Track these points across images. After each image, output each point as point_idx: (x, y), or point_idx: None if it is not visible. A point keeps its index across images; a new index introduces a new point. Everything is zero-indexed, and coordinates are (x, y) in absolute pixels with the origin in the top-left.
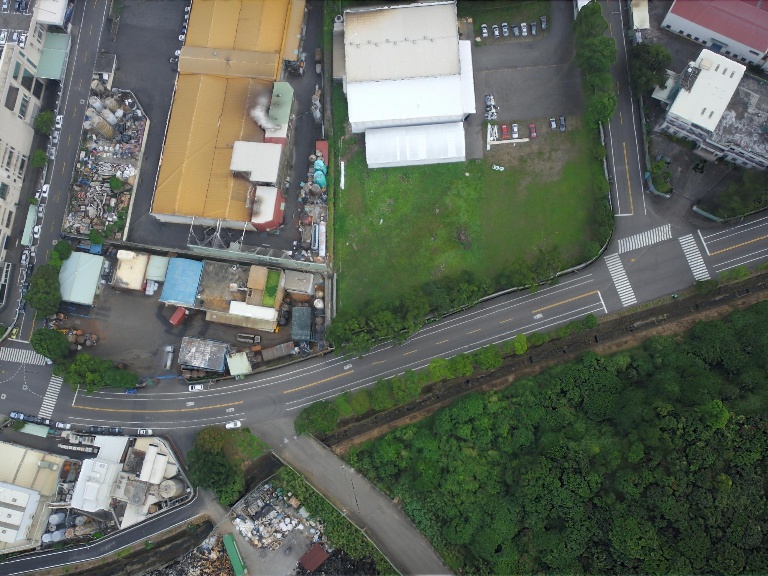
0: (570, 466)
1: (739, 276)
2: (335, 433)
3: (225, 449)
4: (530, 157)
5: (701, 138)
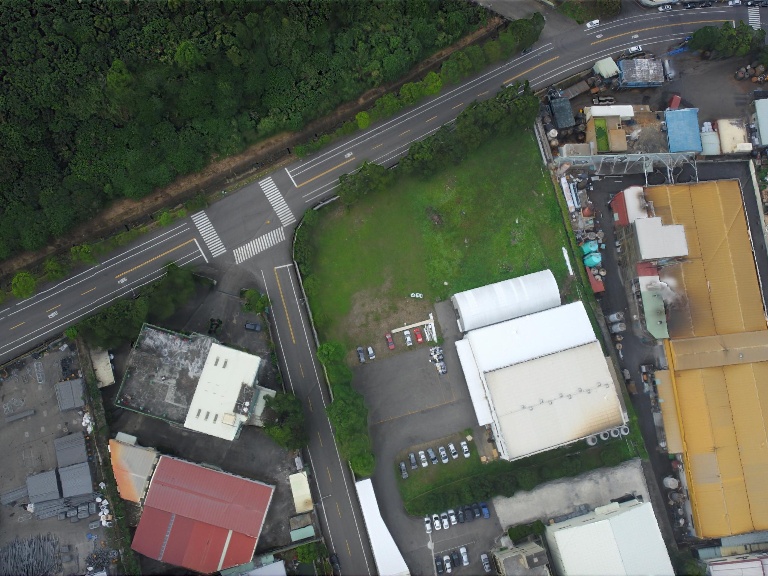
0: (305, 7)
1: None
2: None
3: (593, 4)
4: (387, 313)
5: None
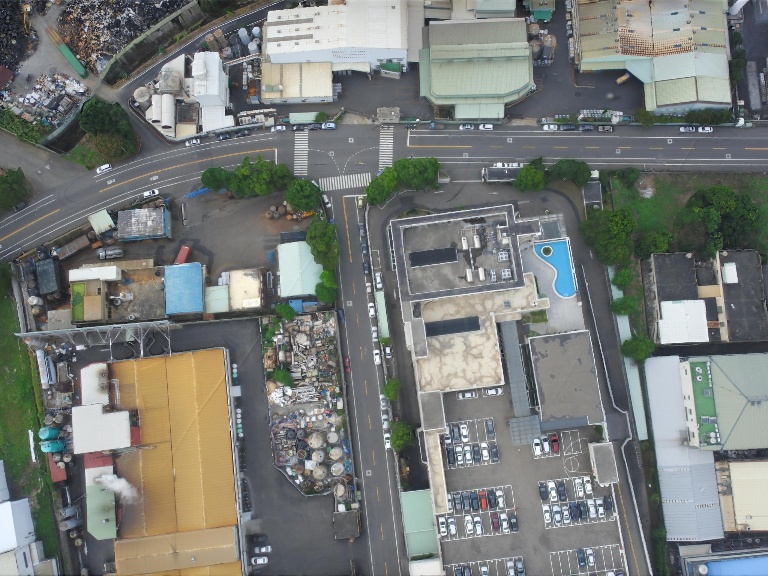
0: None
1: None
2: None
3: None
4: None
5: None
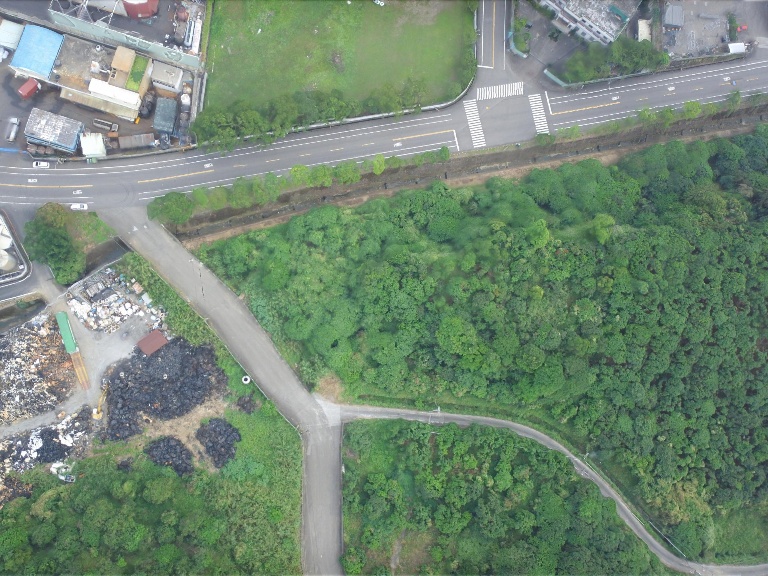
0: (410, 270)
1: (573, 136)
2: (187, 231)
3: (67, 230)
4: None
5: (560, 8)
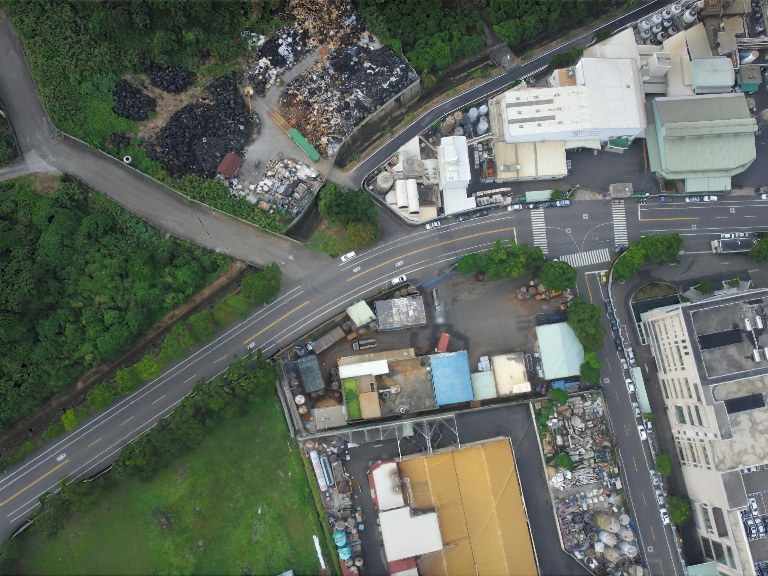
0: None
1: None
2: None
3: None
4: None
5: None
